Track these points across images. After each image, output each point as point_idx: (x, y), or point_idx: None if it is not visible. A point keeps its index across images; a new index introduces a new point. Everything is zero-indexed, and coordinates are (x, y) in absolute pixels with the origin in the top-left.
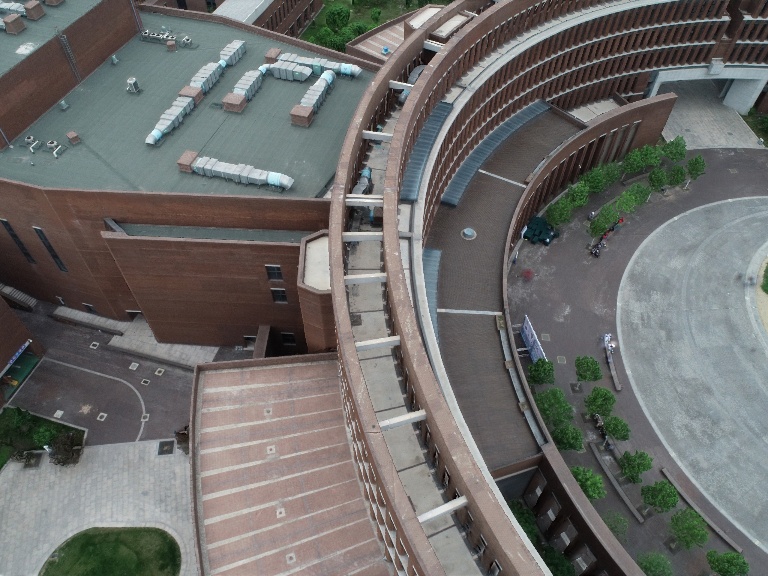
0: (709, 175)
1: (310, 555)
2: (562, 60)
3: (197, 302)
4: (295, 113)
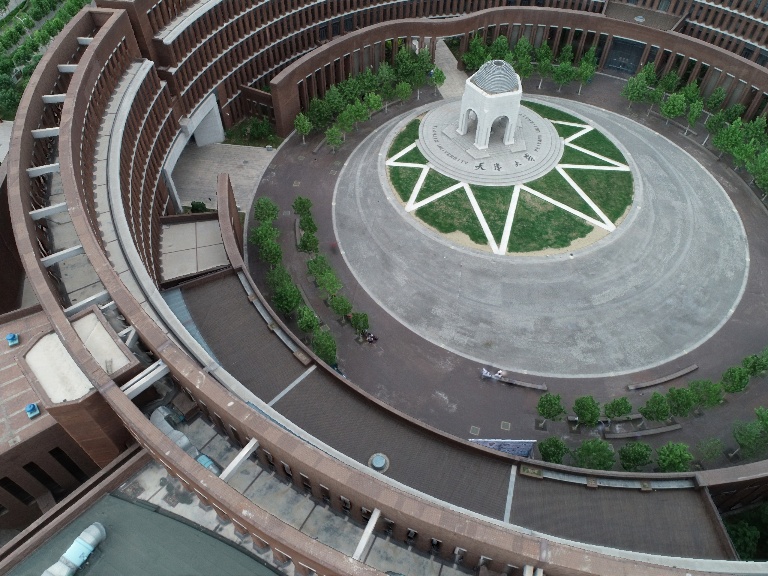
0: None
1: None
2: None
3: None
4: None
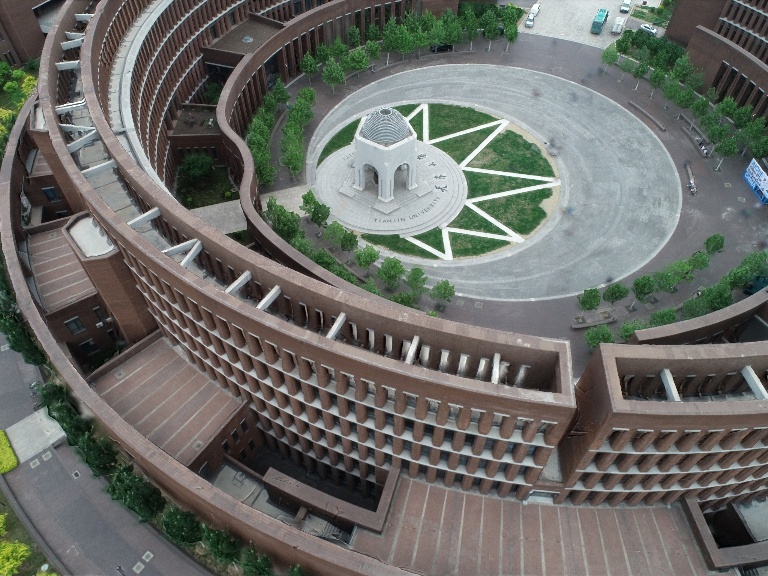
0: (543, 335)
1: None
2: None
3: None
4: None
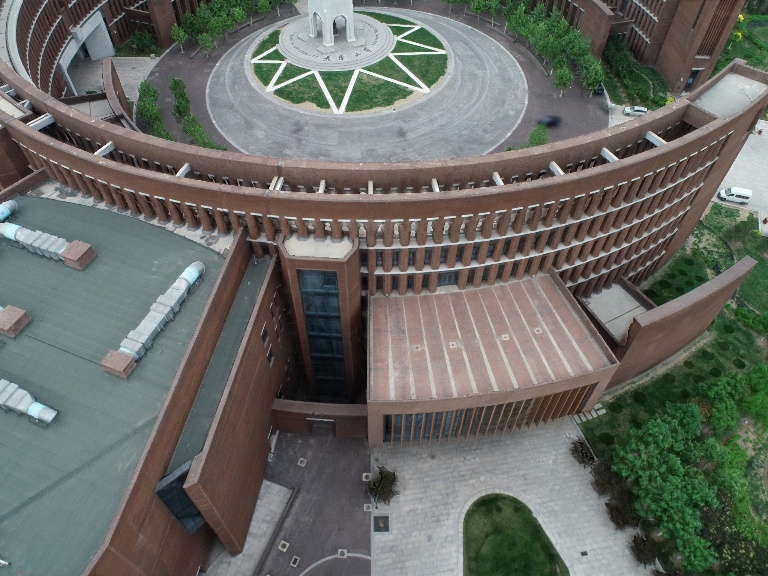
0: None
1: (535, 319)
2: None
3: (247, 450)
4: (78, 255)
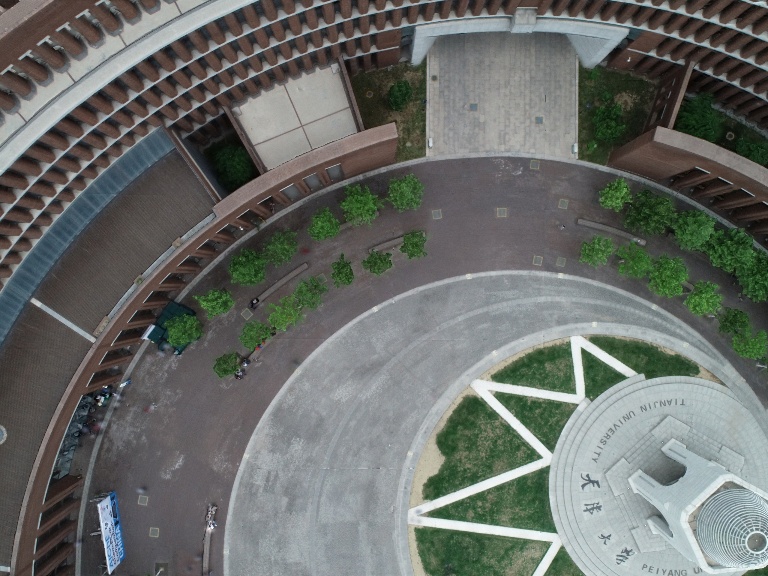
0: (461, 220)
1: None
2: (170, 80)
3: None
4: None
